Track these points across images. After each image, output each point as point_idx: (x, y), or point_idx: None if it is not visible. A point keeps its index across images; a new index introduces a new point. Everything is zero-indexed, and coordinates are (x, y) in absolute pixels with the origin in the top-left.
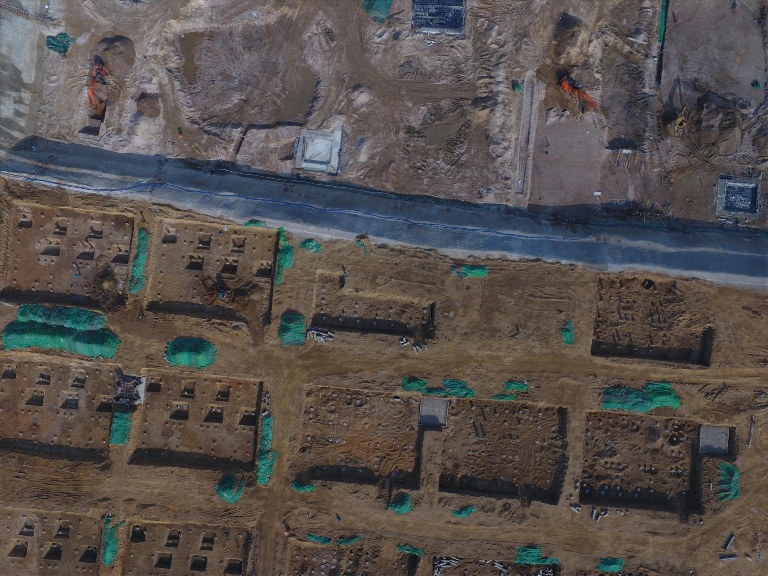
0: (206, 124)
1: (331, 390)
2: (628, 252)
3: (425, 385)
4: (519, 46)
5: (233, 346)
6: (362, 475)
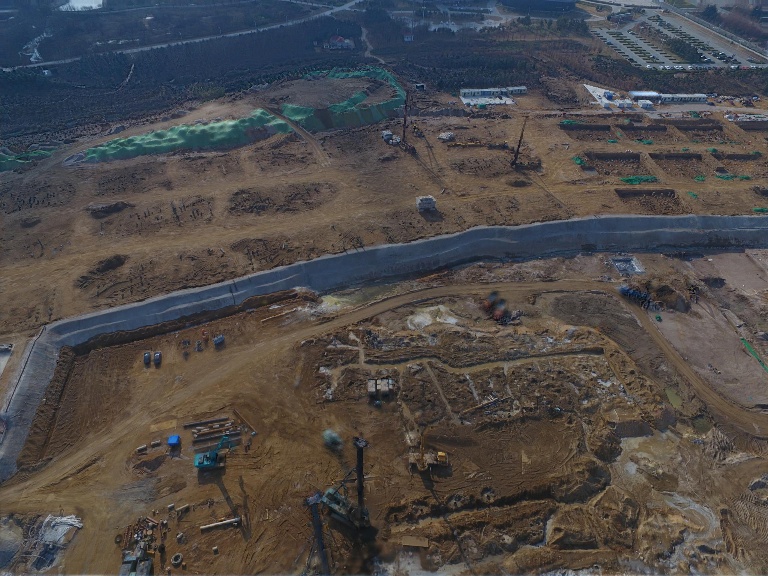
0: None
1: None
2: (687, 224)
3: None
4: None
5: None
6: None
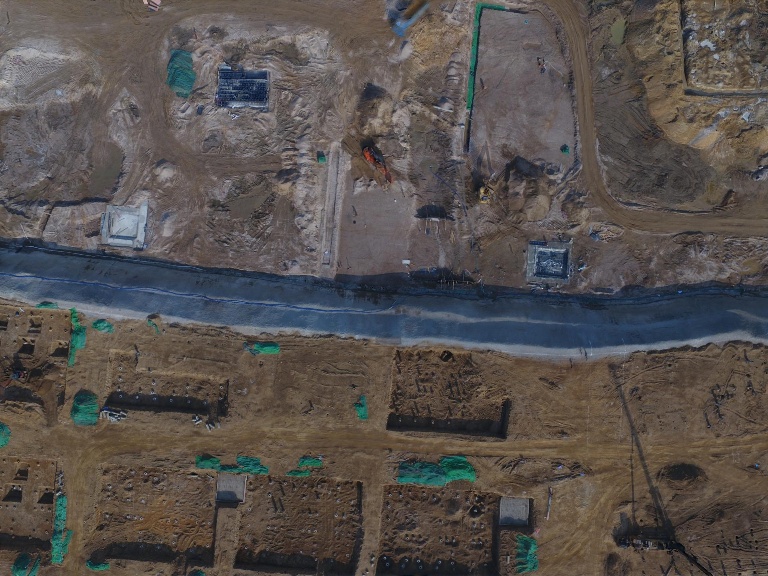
0: (12, 202)
1: (128, 468)
2: (425, 324)
3: (219, 462)
4: (323, 117)
5: (27, 427)
6: (160, 552)
